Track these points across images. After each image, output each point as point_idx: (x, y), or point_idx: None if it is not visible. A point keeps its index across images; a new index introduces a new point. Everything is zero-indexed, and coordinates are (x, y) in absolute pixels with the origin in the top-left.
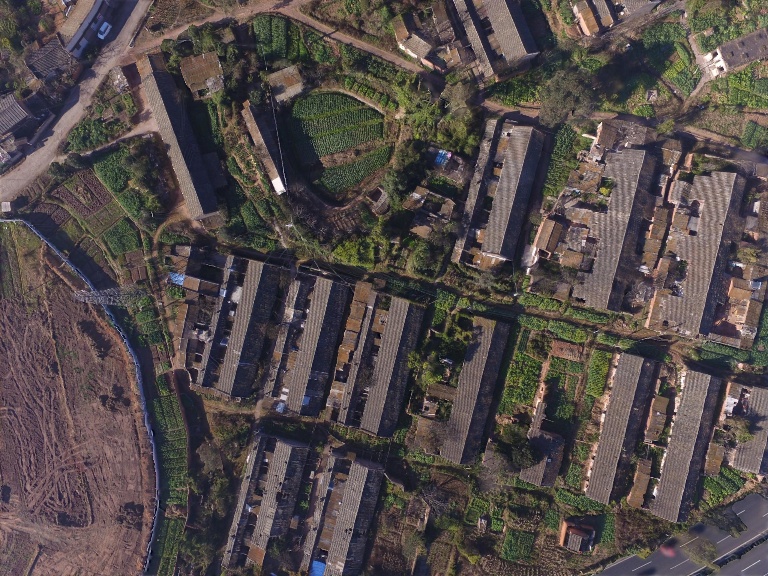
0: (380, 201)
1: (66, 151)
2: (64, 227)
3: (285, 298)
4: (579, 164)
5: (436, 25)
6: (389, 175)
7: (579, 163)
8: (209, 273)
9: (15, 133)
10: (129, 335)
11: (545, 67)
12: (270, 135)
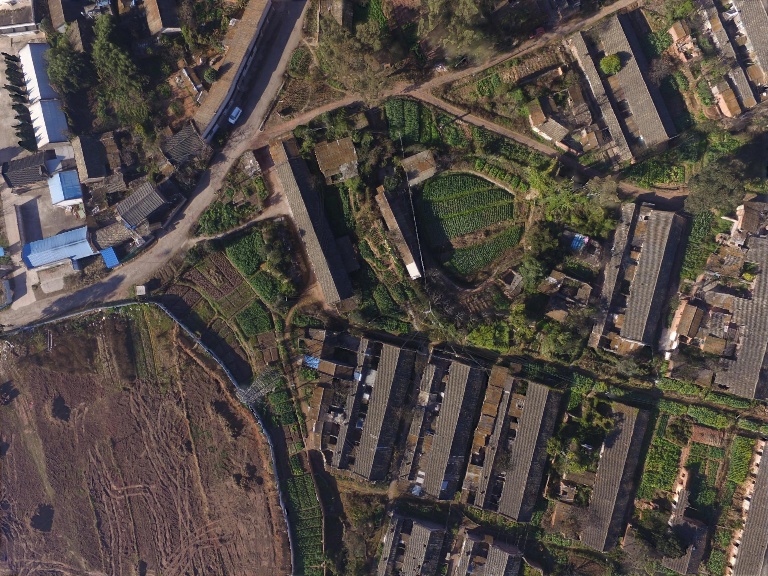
0: (514, 284)
1: (197, 234)
2: (196, 308)
3: (419, 381)
4: (719, 247)
5: (572, 108)
6: (532, 264)
7: (719, 246)
8: (342, 356)
9: (149, 218)
10: (262, 416)
11: (682, 148)
12: (404, 220)
